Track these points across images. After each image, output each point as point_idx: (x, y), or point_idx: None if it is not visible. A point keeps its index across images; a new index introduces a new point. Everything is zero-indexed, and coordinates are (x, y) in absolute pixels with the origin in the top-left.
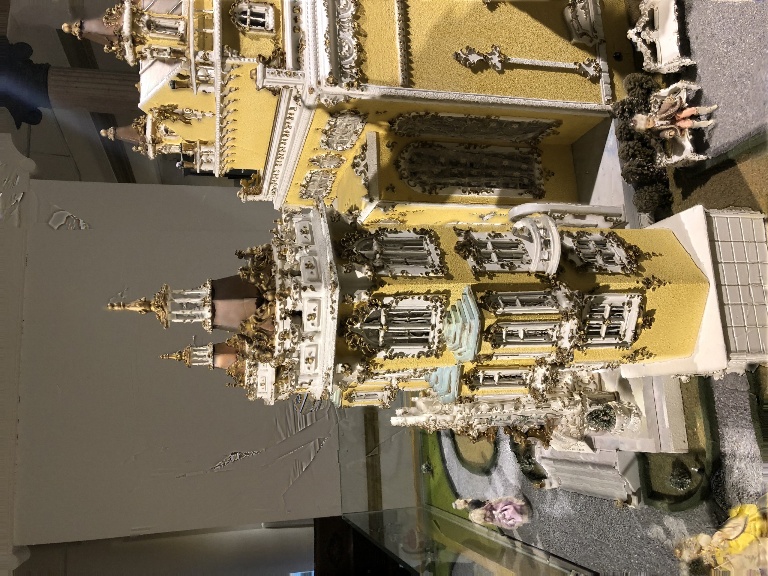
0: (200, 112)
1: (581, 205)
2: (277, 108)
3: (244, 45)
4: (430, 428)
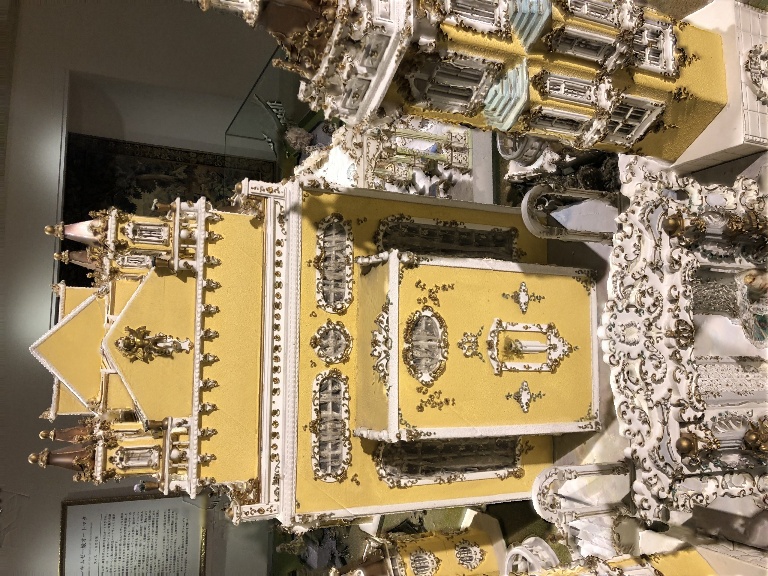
0: (175, 339)
1: None
2: (264, 250)
3: None
4: None
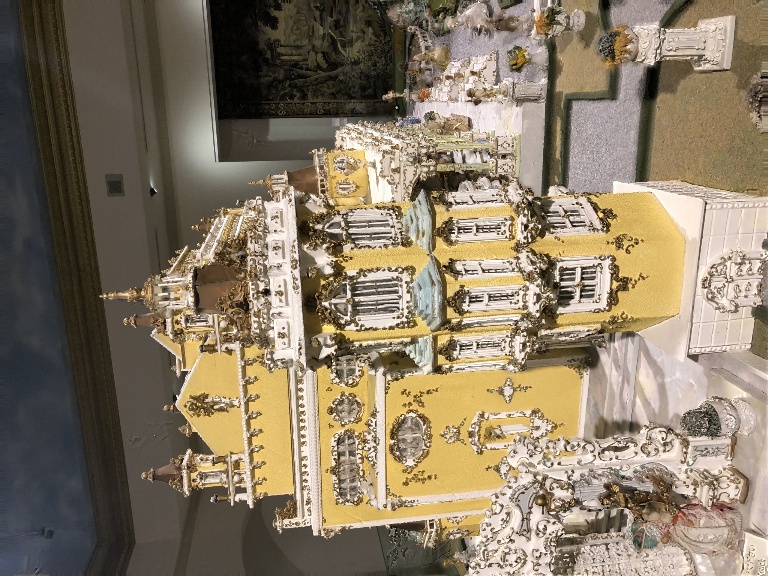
0: (228, 399)
1: None
2: None
3: None
4: None
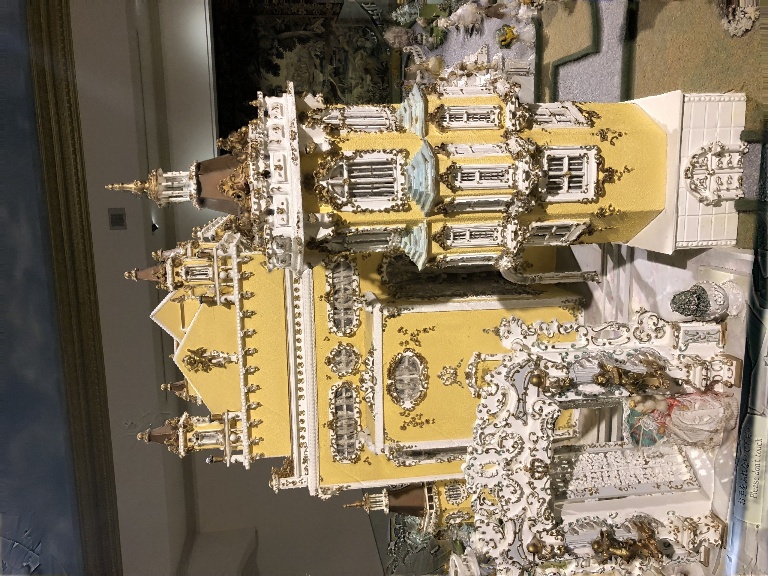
0: (226, 354)
1: None
2: (284, 287)
3: None
4: (543, 544)
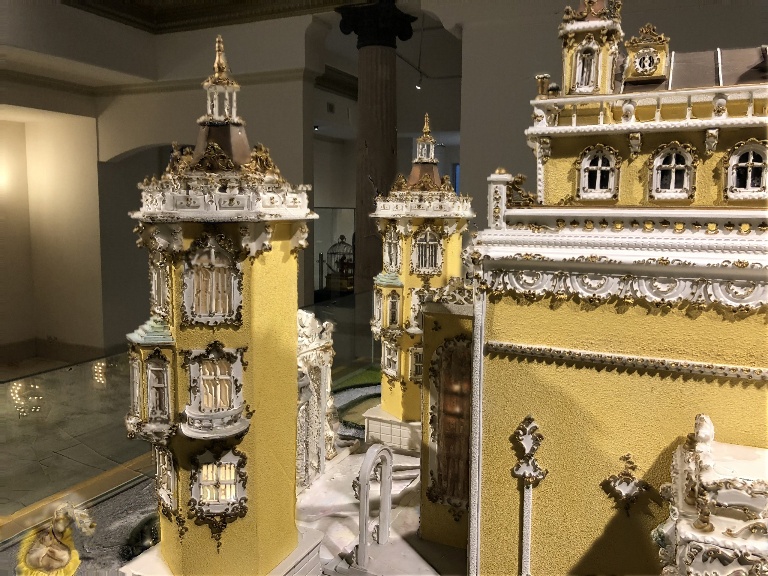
0: None
1: (366, 521)
2: None
3: (561, 163)
4: None
